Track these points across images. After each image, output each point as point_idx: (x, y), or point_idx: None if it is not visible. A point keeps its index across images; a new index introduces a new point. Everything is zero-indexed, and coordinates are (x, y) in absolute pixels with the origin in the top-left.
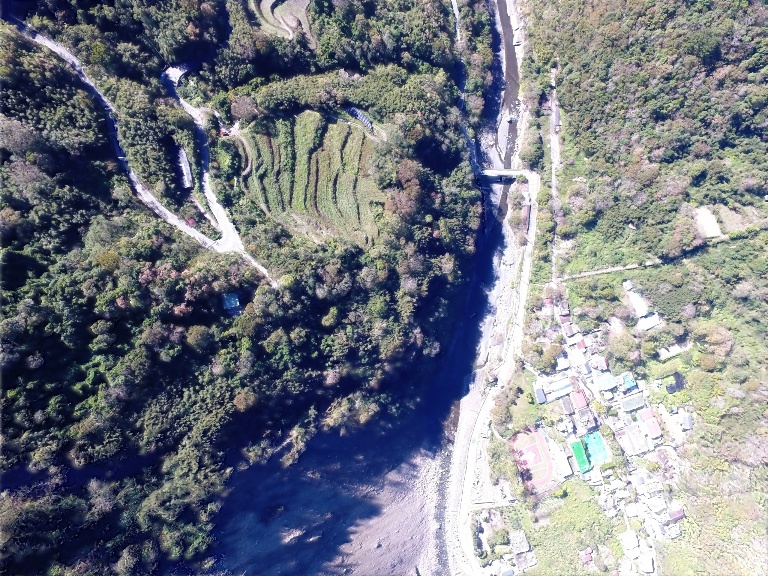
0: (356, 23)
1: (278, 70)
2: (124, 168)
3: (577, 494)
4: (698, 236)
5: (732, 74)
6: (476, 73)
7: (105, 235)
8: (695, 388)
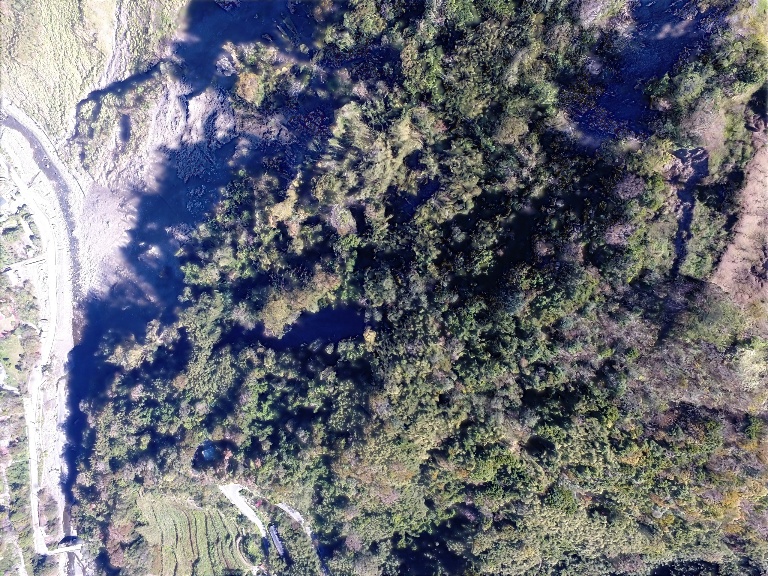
0: None
1: None
2: None
3: None
4: None
5: None
6: None
7: None
8: None
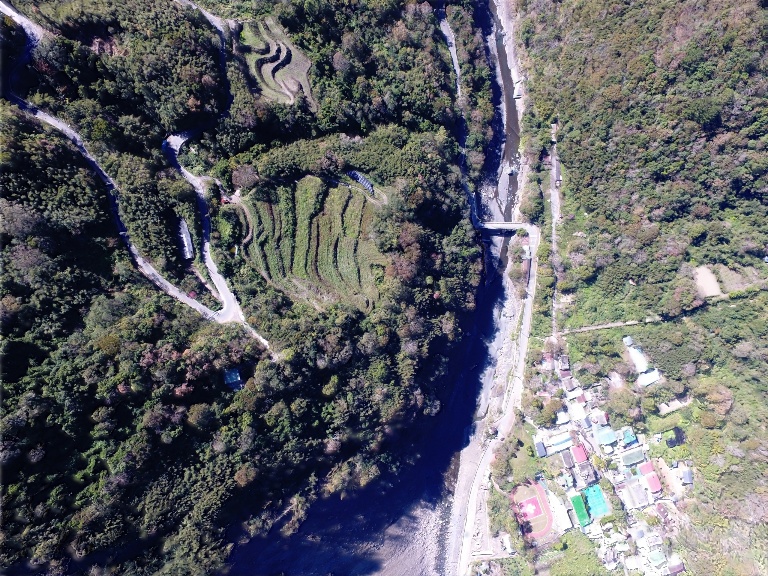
0: (357, 86)
1: (279, 135)
2: (125, 241)
3: (577, 546)
4: (698, 297)
5: (732, 141)
6: (477, 129)
7: (106, 316)
8: (695, 444)
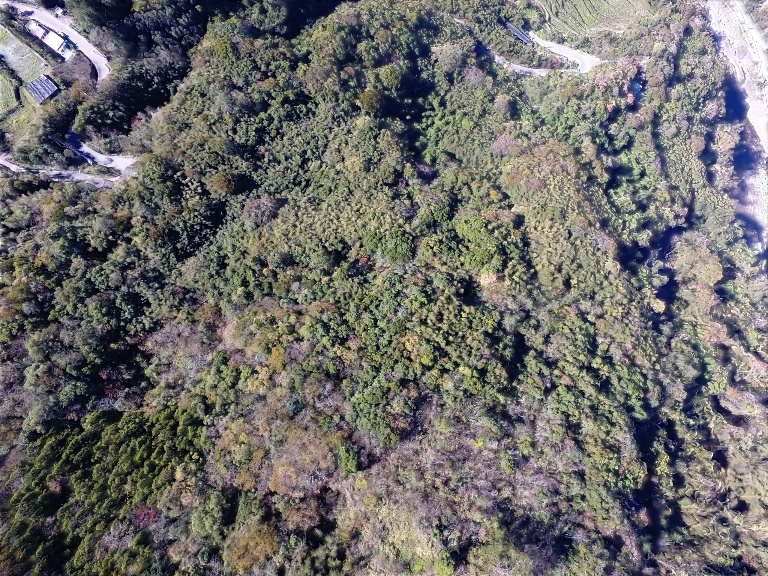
0: None
1: None
2: None
3: None
4: None
5: None
6: None
7: None
8: None
